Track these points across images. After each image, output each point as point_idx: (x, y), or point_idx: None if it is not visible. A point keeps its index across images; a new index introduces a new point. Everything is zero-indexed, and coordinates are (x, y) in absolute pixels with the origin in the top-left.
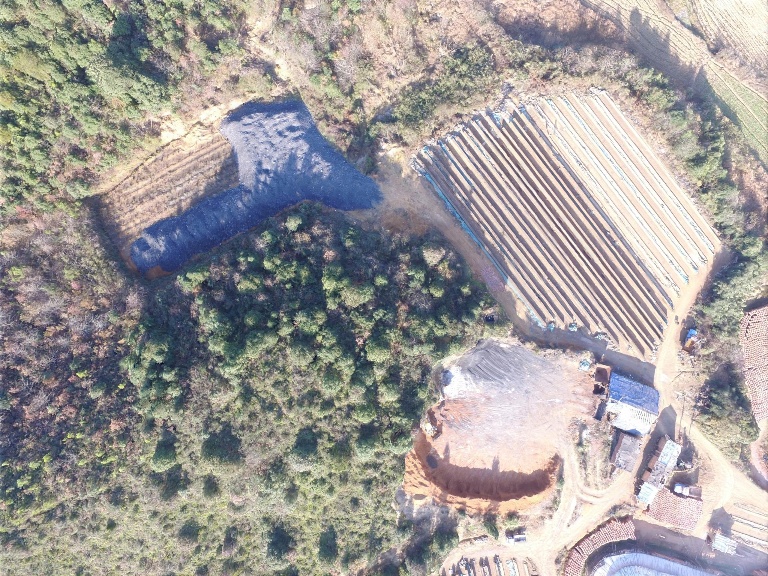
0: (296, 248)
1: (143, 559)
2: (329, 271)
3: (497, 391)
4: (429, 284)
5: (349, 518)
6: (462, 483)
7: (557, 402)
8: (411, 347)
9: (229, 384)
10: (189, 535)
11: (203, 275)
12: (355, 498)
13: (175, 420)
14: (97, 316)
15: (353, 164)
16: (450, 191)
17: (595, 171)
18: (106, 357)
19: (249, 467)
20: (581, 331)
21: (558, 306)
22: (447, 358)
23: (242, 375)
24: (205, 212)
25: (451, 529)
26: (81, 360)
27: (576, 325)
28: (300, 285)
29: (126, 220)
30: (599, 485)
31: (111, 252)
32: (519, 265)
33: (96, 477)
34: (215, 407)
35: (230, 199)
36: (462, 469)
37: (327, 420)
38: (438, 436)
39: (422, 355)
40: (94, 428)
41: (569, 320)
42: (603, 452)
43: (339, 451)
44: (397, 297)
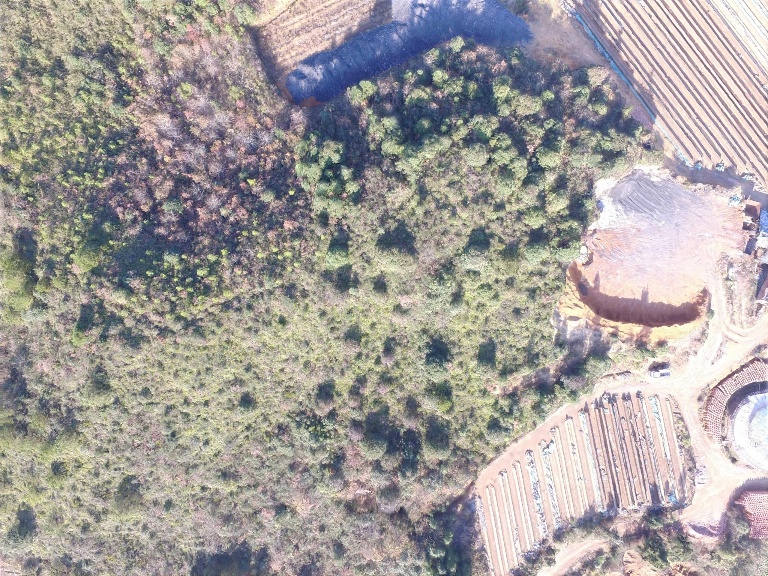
0: (462, 66)
1: (307, 362)
2: (502, 79)
3: (647, 223)
4: (592, 103)
5: (510, 329)
6: (612, 312)
7: (707, 236)
8: (582, 155)
9: (407, 180)
10: (354, 338)
11: (373, 87)
12: (517, 308)
13: (349, 218)
14: (262, 132)
15: (503, 4)
16: (599, 32)
17: (743, 16)
18: (273, 169)
19: (421, 266)
20: (728, 172)
21: (706, 146)
22: (602, 184)
23: (419, 173)
24: (361, 44)
25: (603, 353)
26: (249, 170)
27: (723, 165)
28: (467, 100)
29: (282, 52)
30: (744, 324)
31: (269, 80)
32: (668, 104)
33: (272, 271)
34: (390, 205)
35: (385, 32)
36: (612, 298)
37: (499, 221)
38: (590, 263)
39: (588, 169)
40: (267, 228)
41: (716, 160)
42: (749, 290)
43: (508, 255)
44: (562, 114)
